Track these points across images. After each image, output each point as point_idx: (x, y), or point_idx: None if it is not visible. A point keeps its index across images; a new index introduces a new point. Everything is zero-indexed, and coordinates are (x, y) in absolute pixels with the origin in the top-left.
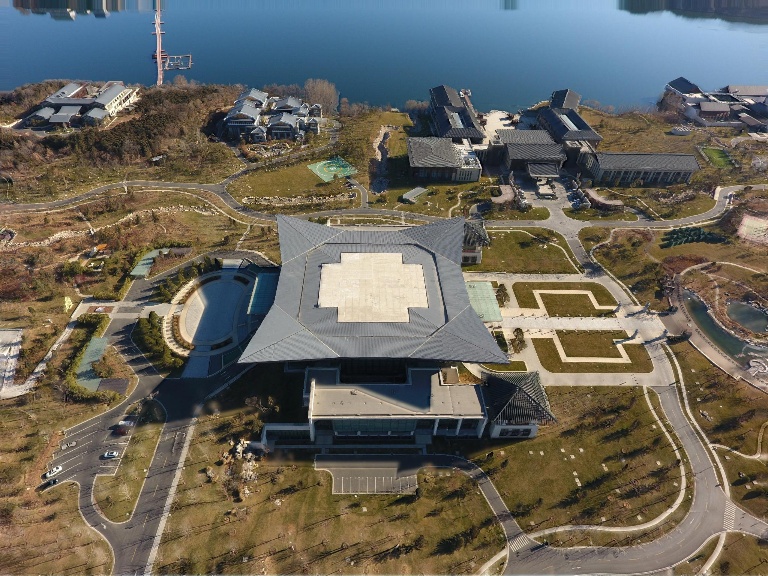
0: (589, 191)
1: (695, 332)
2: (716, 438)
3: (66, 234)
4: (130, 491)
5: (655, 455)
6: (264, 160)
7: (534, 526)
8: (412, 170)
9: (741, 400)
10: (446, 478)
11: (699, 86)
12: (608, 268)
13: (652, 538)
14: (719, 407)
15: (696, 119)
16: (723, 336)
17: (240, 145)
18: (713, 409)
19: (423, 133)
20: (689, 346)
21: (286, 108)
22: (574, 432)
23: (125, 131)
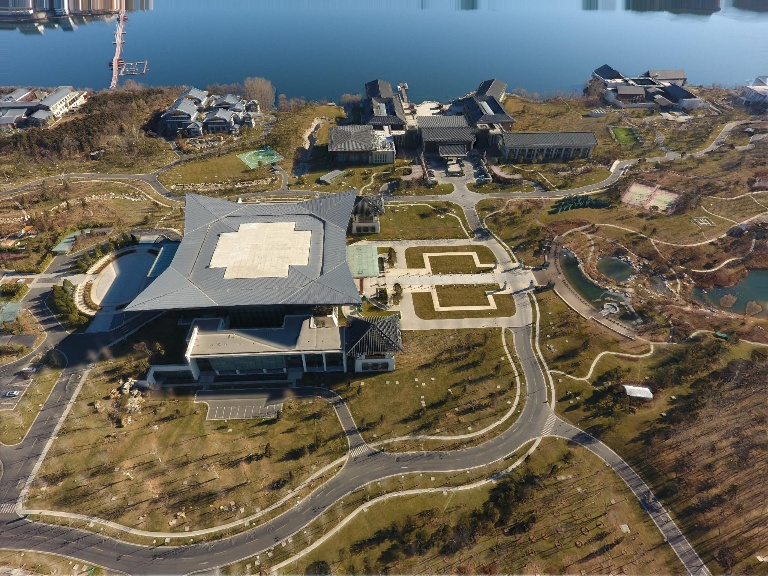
0: (493, 168)
1: (562, 283)
2: (555, 366)
3: (2, 221)
4: (24, 421)
5: (497, 381)
6: (195, 151)
7: (375, 438)
8: (332, 155)
9: (586, 335)
10: (308, 404)
11: (620, 72)
12: (496, 233)
13: (477, 444)
14: (565, 341)
15: (614, 102)
16: (587, 285)
17: (177, 139)
18: (559, 343)
19: (353, 123)
20: (553, 294)
21: (224, 105)
22: (430, 365)
23: (66, 129)
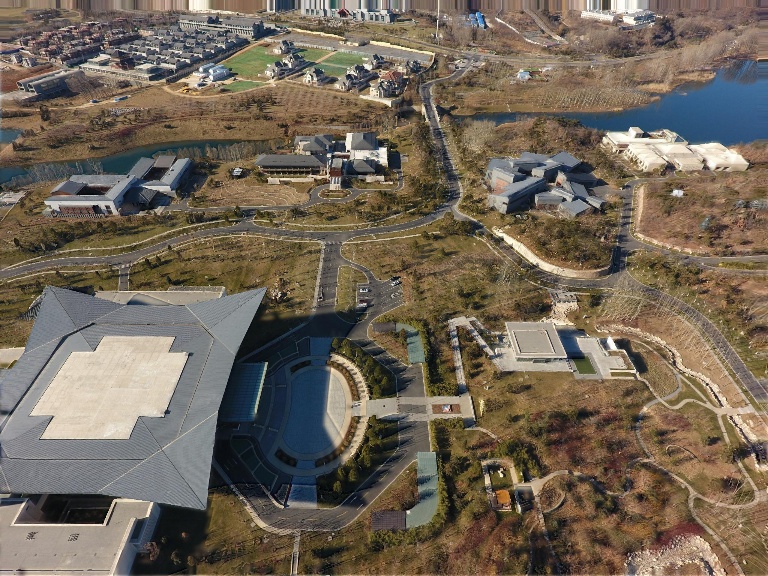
0: None
1: None
2: None
3: None
4: None
5: None
6: None
7: None
8: None
9: None
10: None
11: None
12: None
13: None
14: None
15: None
16: None
17: None
18: None
19: None
20: None
21: None
22: None
23: None
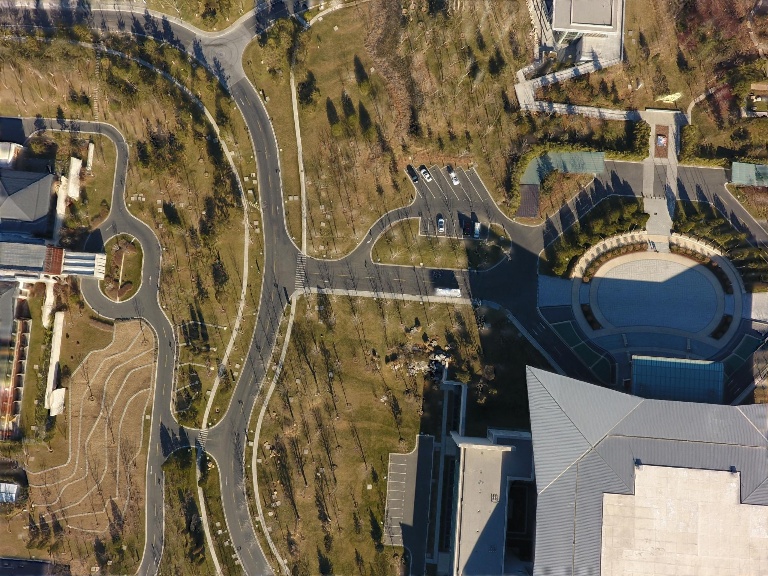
0: None
1: None
2: None
3: None
4: (400, 256)
5: None
6: None
7: None
8: None
9: None
10: None
11: None
12: None
13: None
14: None
15: None
16: None
17: None
18: None
19: None
20: None
21: None
22: None
23: None
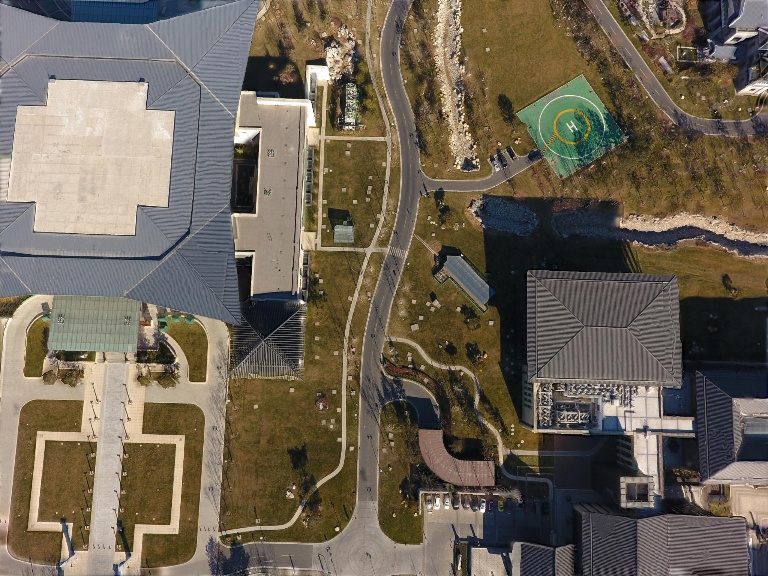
0: None
1: None
2: None
3: None
4: None
5: None
6: None
7: None
8: None
9: None
10: None
11: None
12: None
13: None
14: None
15: None
16: None
17: None
18: None
19: None
20: None
21: None
22: None
23: None
